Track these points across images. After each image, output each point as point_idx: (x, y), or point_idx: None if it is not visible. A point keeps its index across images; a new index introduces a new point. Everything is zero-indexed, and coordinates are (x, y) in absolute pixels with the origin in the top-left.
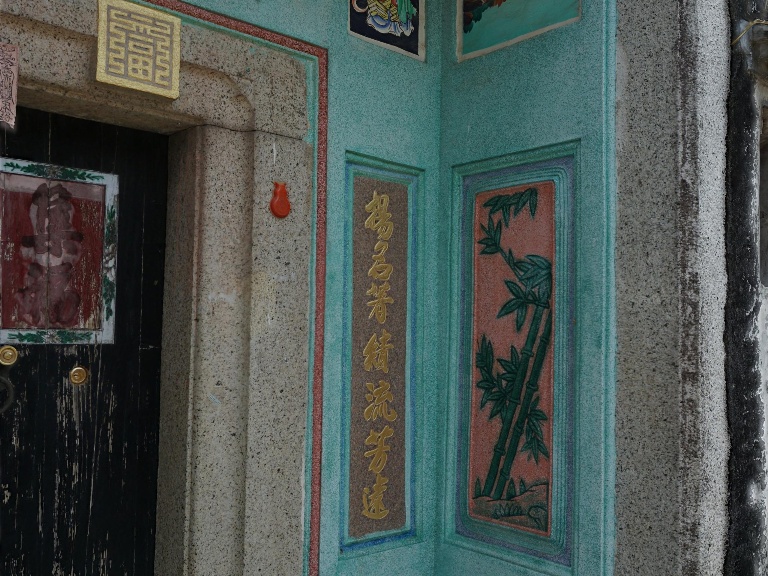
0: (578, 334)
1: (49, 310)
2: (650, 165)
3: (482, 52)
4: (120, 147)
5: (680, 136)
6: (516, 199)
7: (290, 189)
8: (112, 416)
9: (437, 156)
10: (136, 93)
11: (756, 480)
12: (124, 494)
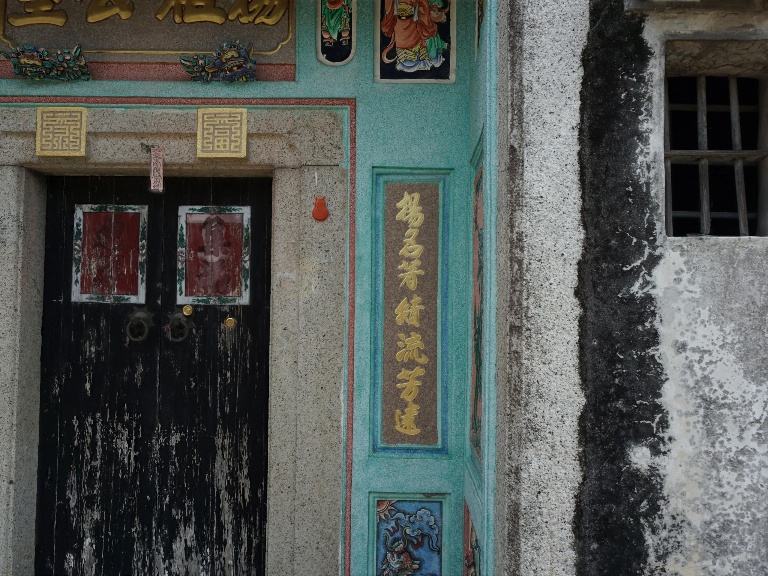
0: None
1: (213, 286)
2: None
3: None
4: (251, 190)
5: (509, 105)
6: None
7: (329, 200)
8: (249, 347)
9: (467, 155)
10: (224, 159)
11: (639, 443)
12: (257, 393)
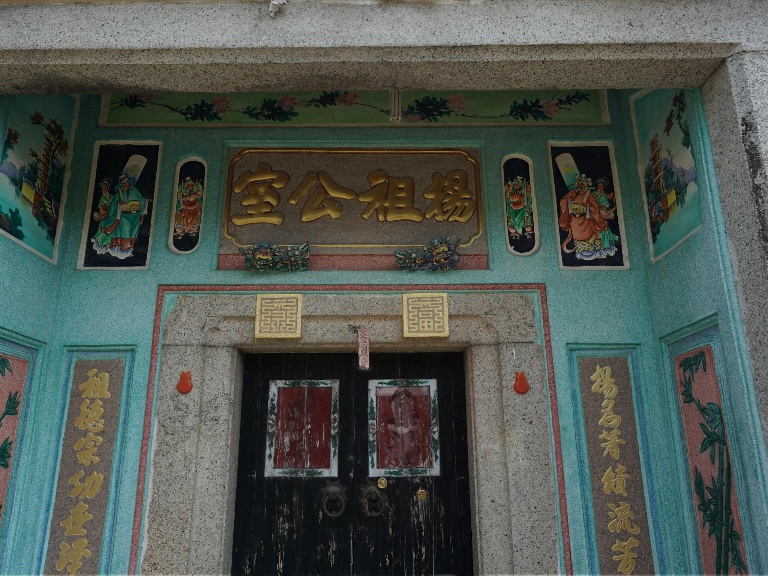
0: (744, 467)
1: (404, 457)
2: (763, 328)
3: (662, 255)
4: (436, 363)
5: None
6: (694, 360)
7: (528, 375)
8: (442, 519)
9: (650, 332)
10: (427, 338)
11: None
12: (453, 569)
